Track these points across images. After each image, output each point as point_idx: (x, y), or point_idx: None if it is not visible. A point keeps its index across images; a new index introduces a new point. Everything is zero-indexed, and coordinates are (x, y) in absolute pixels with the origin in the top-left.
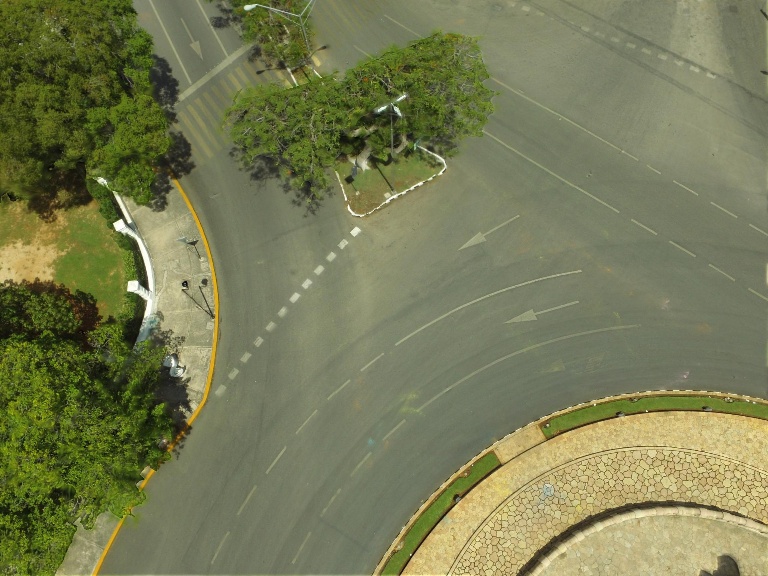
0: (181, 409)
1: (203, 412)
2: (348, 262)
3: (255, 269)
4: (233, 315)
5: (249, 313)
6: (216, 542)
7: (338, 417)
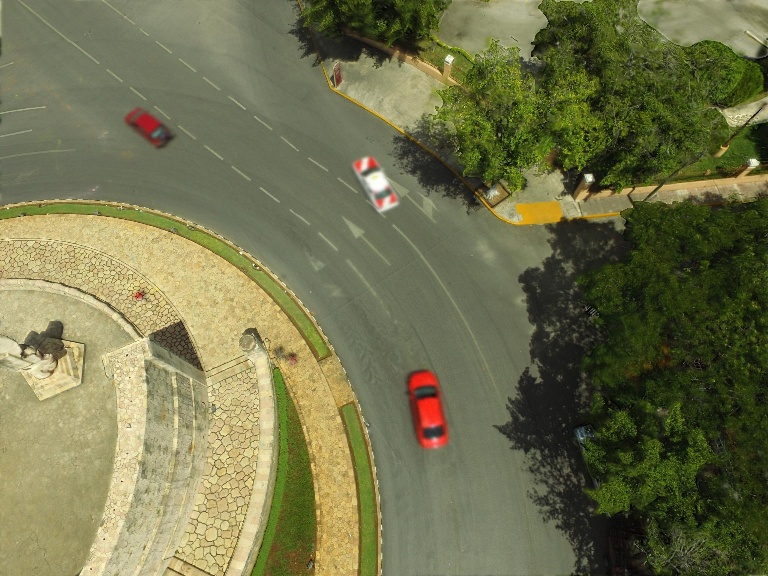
0: None
1: None
2: None
3: None
4: None
5: None
6: None
7: None
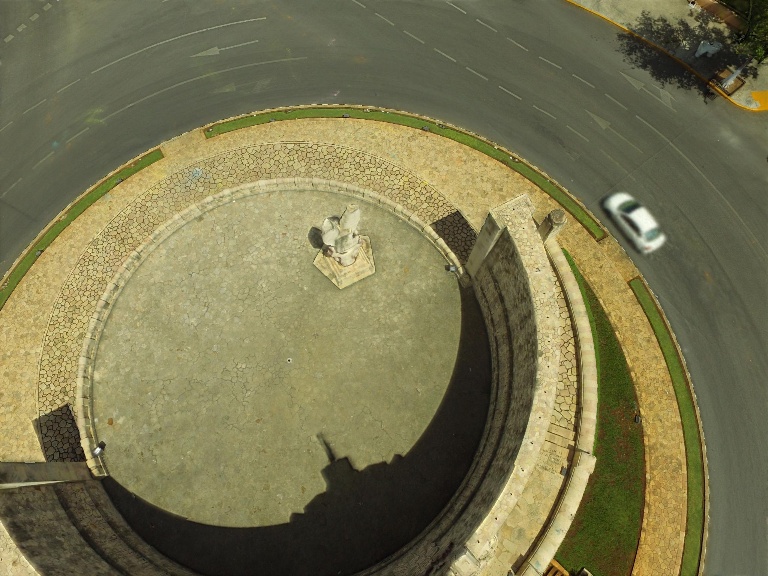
0: None
1: None
2: (61, 11)
3: None
4: None
5: None
6: None
7: (30, 126)
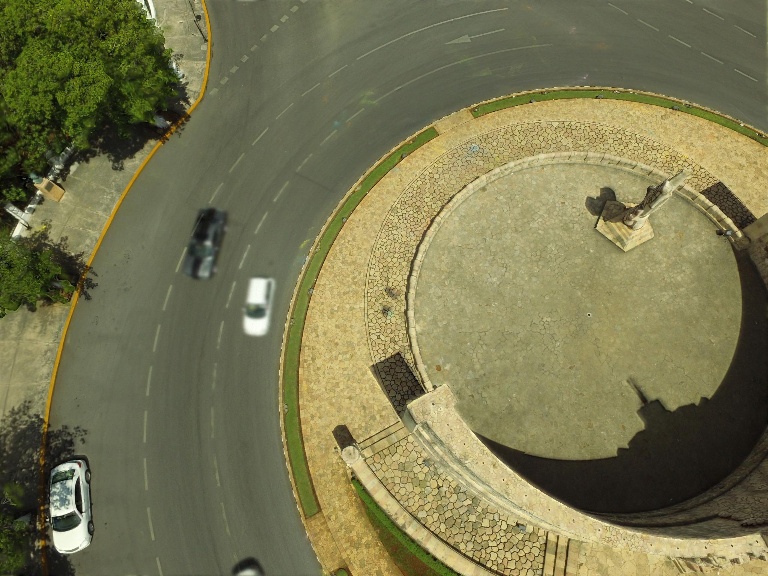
0: (181, 103)
1: (200, 106)
2: (318, 3)
3: (241, 9)
4: (223, 41)
5: (236, 39)
6: (213, 189)
7: (310, 108)
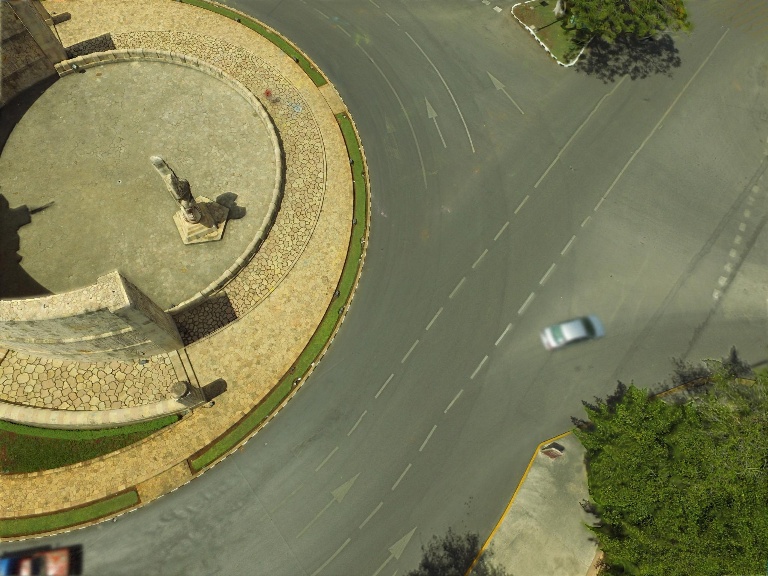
0: None
1: None
2: (471, 5)
3: None
4: None
5: None
6: None
7: (353, 2)
